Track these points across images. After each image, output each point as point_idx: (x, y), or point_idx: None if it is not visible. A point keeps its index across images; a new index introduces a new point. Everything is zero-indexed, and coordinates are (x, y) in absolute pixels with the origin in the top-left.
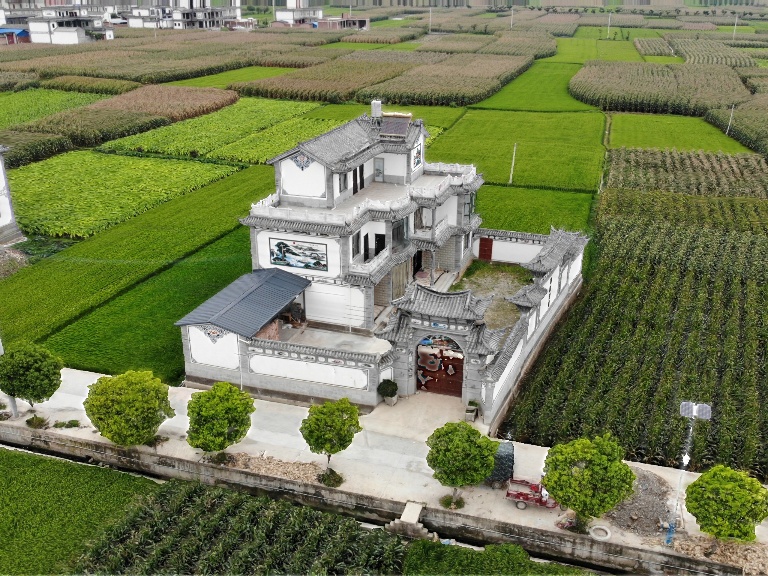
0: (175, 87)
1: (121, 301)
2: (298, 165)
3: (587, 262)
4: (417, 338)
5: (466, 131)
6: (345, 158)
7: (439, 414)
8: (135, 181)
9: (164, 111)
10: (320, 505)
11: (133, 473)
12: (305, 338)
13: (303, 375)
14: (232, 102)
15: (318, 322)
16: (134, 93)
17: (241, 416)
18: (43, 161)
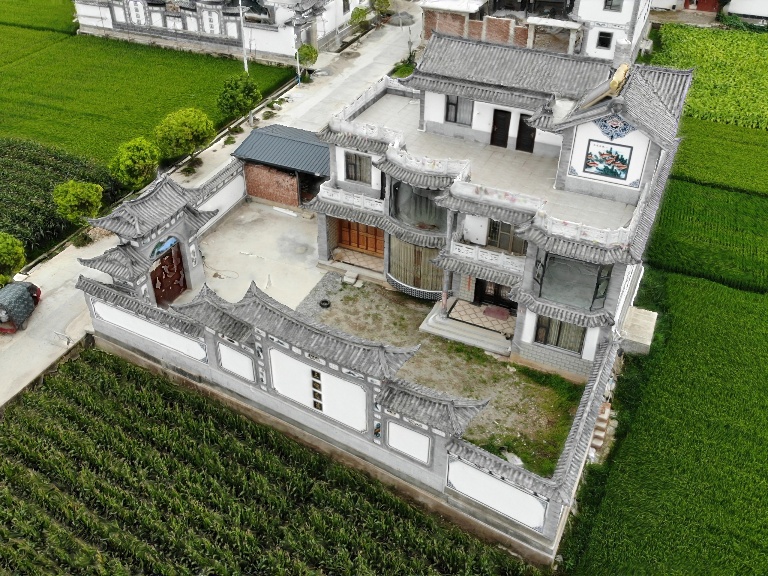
0: None
1: None
2: None
3: None
4: None
5: None
6: None
7: None
8: None
9: None
10: None
11: None
12: None
13: None
14: None
15: None
16: None
17: None
18: None
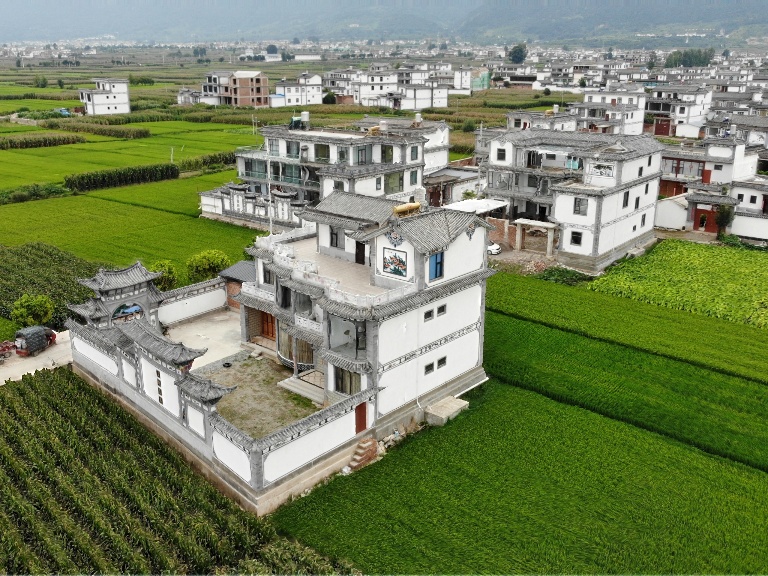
0: None
1: None
2: None
3: (319, 547)
4: None
5: None
6: None
7: None
8: None
9: None
10: None
11: None
12: None
13: None
14: None
15: None
16: None
17: None
18: None
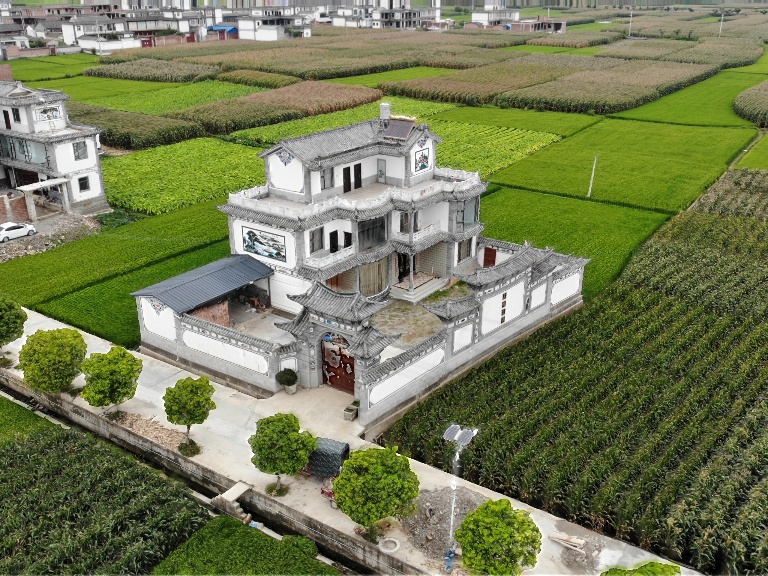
0: (328, 84)
1: (143, 272)
2: (282, 160)
3: (604, 284)
4: (317, 333)
5: (583, 140)
6: (318, 156)
7: (326, 409)
8: (232, 168)
9: (301, 106)
10: (179, 471)
11: (49, 416)
12: (263, 323)
13: (221, 354)
14: (373, 100)
15: (281, 310)
16: (288, 88)
17: (124, 379)
18: (171, 145)
